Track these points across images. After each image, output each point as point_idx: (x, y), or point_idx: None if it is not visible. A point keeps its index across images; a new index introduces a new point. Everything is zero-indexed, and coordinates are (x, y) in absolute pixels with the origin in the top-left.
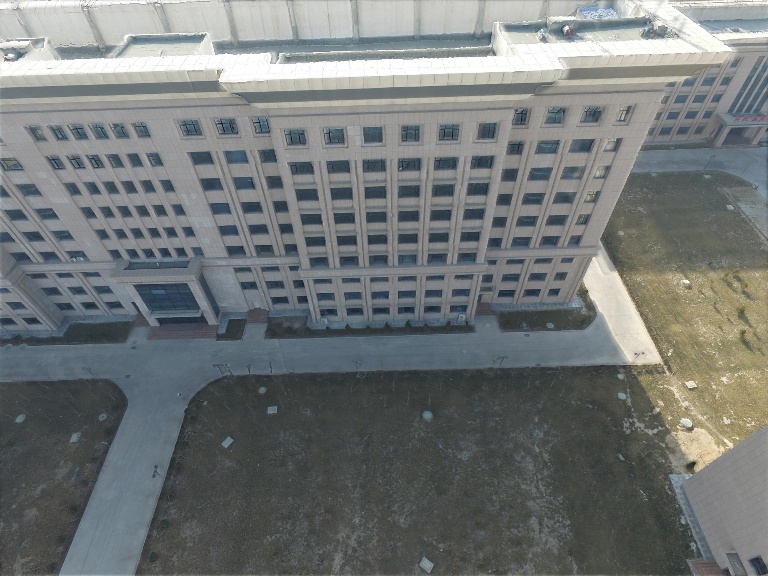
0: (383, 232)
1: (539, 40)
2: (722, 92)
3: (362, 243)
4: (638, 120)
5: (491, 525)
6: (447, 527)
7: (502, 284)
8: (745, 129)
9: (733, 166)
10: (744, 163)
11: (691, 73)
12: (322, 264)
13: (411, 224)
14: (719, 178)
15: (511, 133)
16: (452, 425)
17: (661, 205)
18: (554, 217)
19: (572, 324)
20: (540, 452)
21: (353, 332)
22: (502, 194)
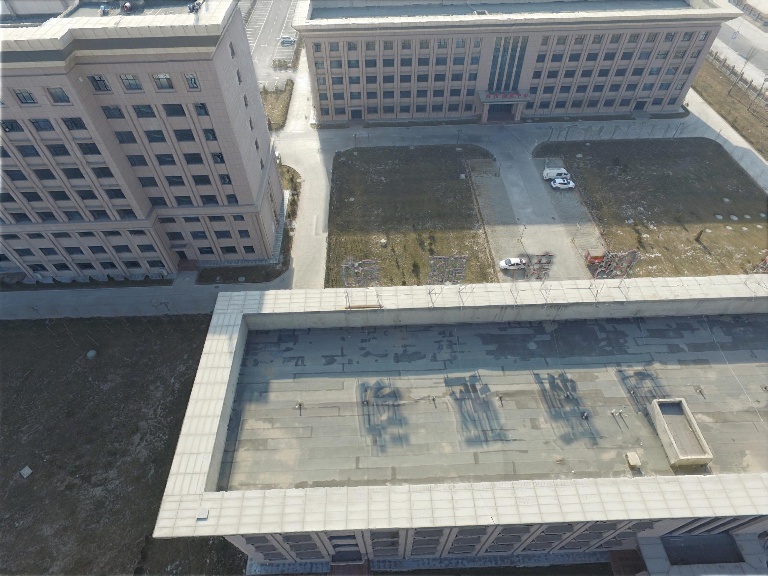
0: (30, 189)
1: (100, 15)
2: (475, 71)
3: (20, 200)
4: (207, 87)
5: (99, 440)
6: (60, 442)
7: (196, 241)
8: (512, 106)
9: (488, 140)
10: (500, 137)
11: (212, 44)
12: (1, 221)
13: (54, 182)
14: (468, 151)
15: (102, 98)
16: (109, 362)
17: (403, 175)
18: (199, 177)
19: (262, 277)
20: (174, 382)
21: (62, 286)
22: (135, 155)
